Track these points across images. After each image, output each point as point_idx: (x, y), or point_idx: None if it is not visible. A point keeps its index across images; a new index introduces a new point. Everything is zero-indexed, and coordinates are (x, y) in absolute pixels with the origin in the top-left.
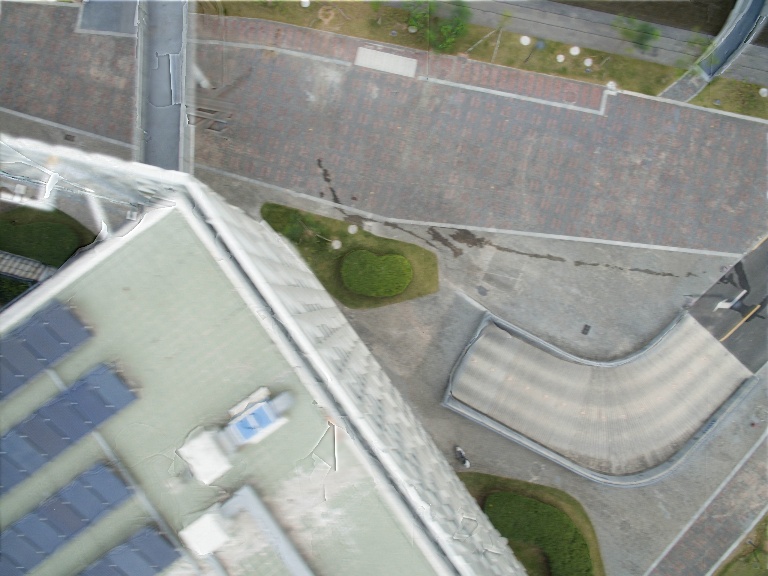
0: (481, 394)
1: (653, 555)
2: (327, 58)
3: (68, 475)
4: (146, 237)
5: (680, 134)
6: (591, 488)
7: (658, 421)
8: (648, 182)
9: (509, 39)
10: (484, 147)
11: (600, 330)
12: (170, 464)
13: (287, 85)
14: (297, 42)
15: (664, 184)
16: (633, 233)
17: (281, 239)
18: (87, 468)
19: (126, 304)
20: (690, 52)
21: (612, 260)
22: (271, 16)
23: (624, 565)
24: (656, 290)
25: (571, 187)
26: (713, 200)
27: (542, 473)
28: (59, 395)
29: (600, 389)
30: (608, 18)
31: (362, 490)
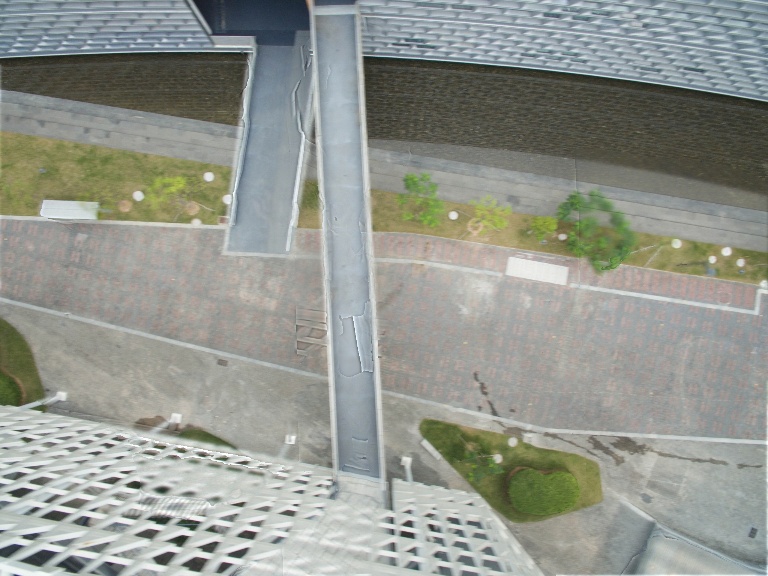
0: None
1: None
2: (478, 269)
3: None
4: None
5: None
6: None
7: None
8: None
9: (660, 243)
10: (640, 353)
11: (767, 533)
12: None
13: (439, 299)
14: (447, 255)
15: None
16: None
17: (441, 456)
18: None
19: None
20: None
21: None
22: (419, 230)
23: None
24: None
25: (730, 389)
26: None
27: None
28: None
29: None
30: (757, 215)
31: None
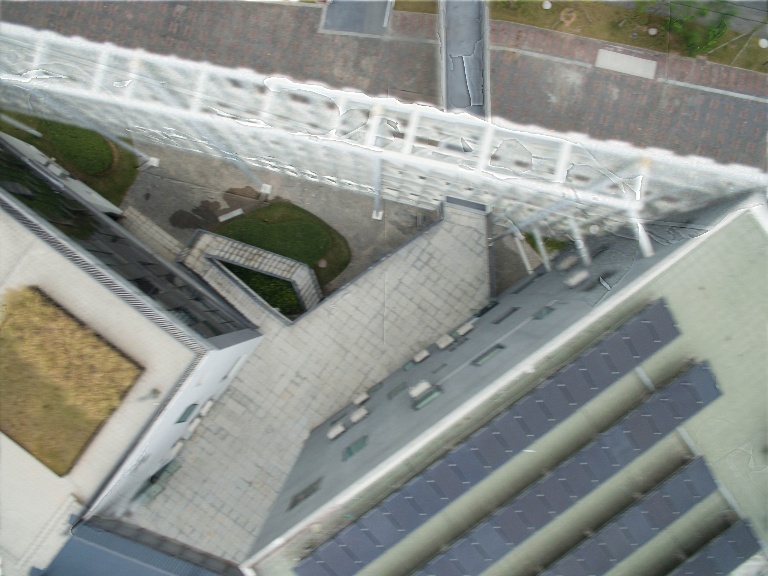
0: None
1: None
2: (568, 60)
3: (656, 469)
4: (719, 238)
5: None
6: None
7: None
8: None
9: None
10: (723, 148)
11: None
12: (749, 458)
13: (529, 86)
14: (538, 44)
15: None
16: None
17: (524, 239)
18: (679, 462)
19: (703, 303)
20: None
21: None
22: (513, 18)
23: None
24: None
25: None
26: None
27: None
28: (649, 391)
29: None
30: None
31: None
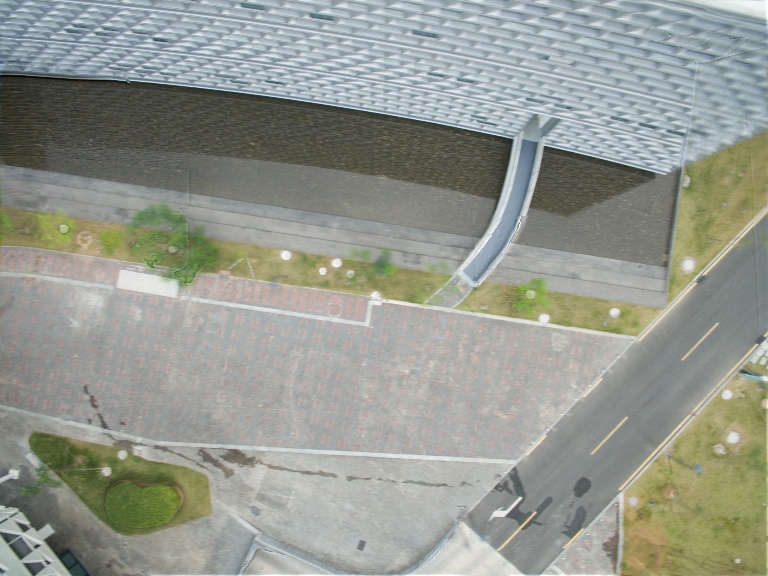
0: None
1: None
2: (89, 283)
3: None
4: None
5: (448, 341)
6: None
7: None
8: (417, 392)
9: (270, 255)
10: (250, 365)
11: (375, 545)
12: None
13: (50, 312)
14: (58, 268)
15: (434, 393)
16: (404, 445)
17: (51, 469)
18: None
19: None
20: (455, 257)
21: (384, 473)
22: (31, 243)
23: None
24: (430, 502)
25: (340, 401)
26: (484, 407)
27: None
28: None
29: None
30: (371, 226)
31: None
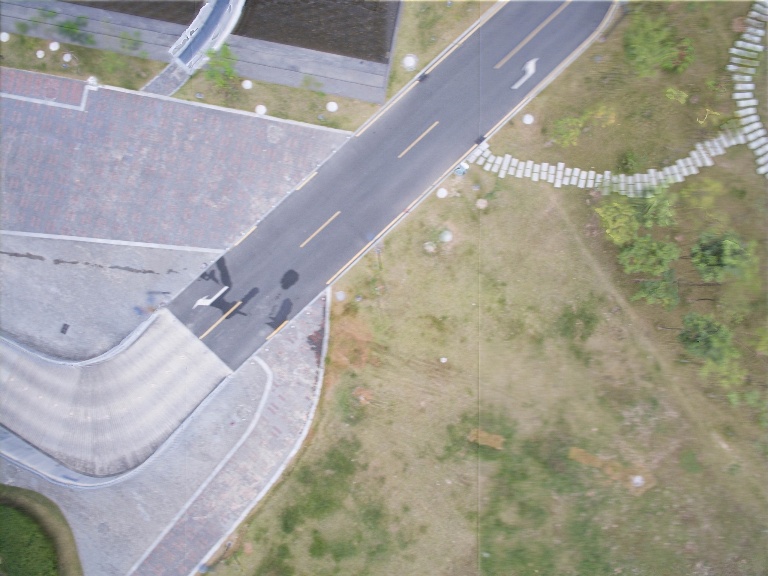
0: None
1: (133, 558)
2: None
3: None
4: None
5: (162, 128)
6: (68, 490)
7: (138, 421)
8: (129, 178)
9: None
10: None
11: (79, 329)
12: None
13: None
14: None
15: (145, 180)
16: (113, 230)
17: None
18: None
19: None
20: None
21: (92, 258)
22: None
23: (103, 568)
24: (136, 288)
25: (51, 184)
26: (195, 195)
27: (18, 475)
28: None
29: (87, 389)
30: (92, 12)
31: None
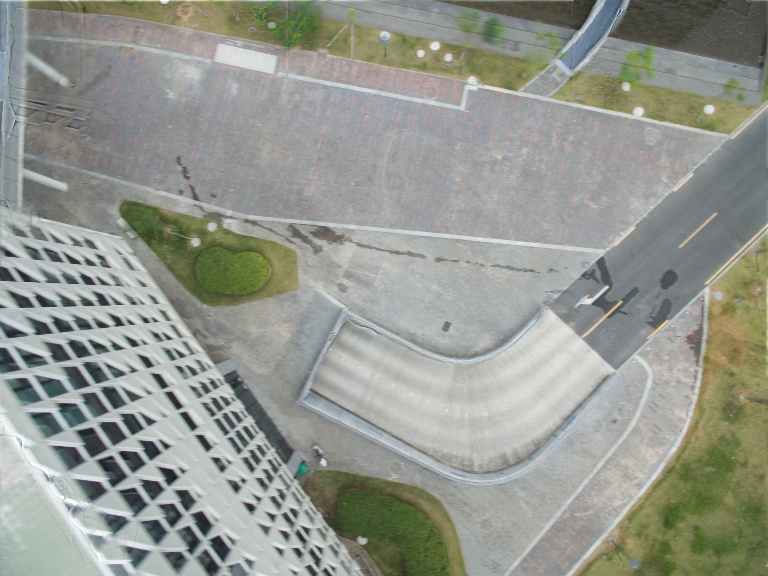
0: (348, 392)
1: (515, 553)
2: (186, 55)
3: None
4: None
5: (542, 129)
6: (451, 486)
7: (520, 418)
8: (509, 177)
9: (368, 34)
10: (344, 143)
11: (461, 327)
12: None
13: (146, 82)
14: (156, 39)
15: (525, 179)
16: (494, 229)
17: (140, 237)
18: None
19: None
20: (552, 46)
21: (473, 256)
22: (130, 13)
23: (485, 564)
24: (517, 286)
25: (431, 183)
26: (575, 195)
27: (402, 471)
28: None
29: (463, 386)
30: (470, 13)
31: (22, 487)
